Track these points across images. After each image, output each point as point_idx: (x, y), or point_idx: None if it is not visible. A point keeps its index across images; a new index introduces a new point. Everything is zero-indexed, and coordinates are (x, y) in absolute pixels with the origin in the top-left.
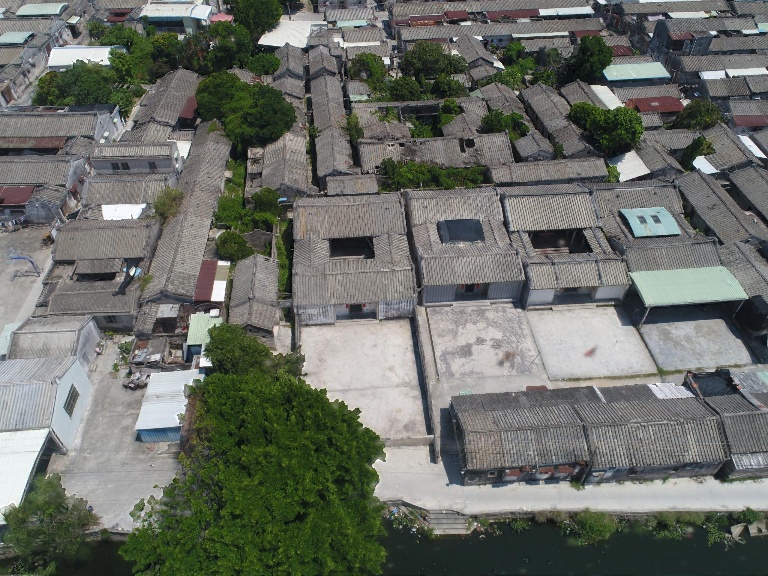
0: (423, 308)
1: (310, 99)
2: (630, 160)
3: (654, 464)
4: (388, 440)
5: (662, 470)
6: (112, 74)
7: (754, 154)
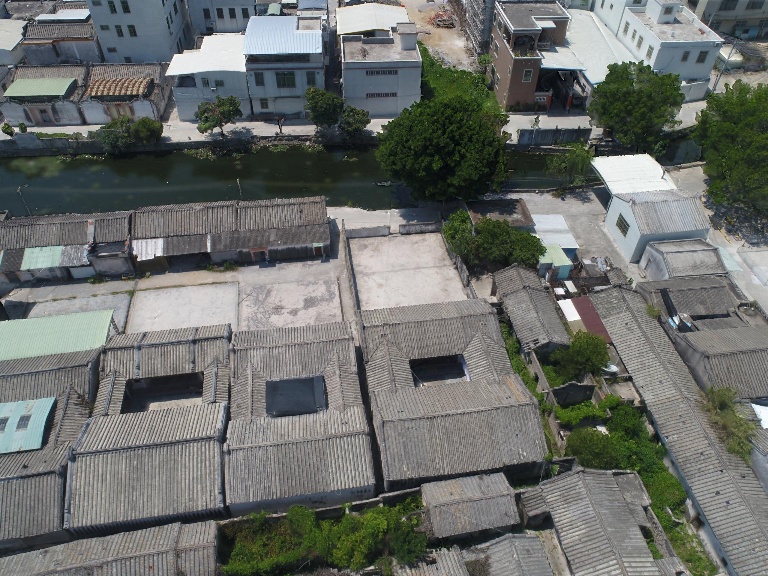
0: None
1: None
2: None
3: None
4: (379, 227)
5: None
6: None
7: None
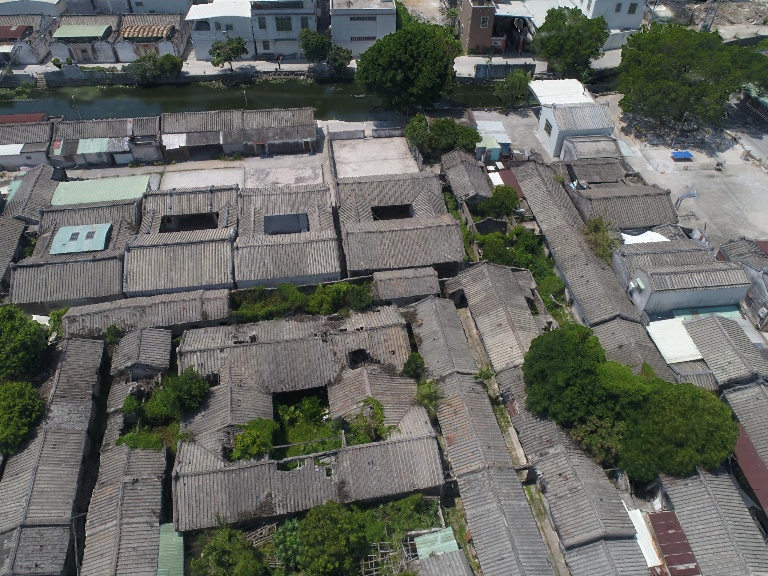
0: None
1: None
2: None
3: None
4: (356, 131)
5: None
6: None
7: None
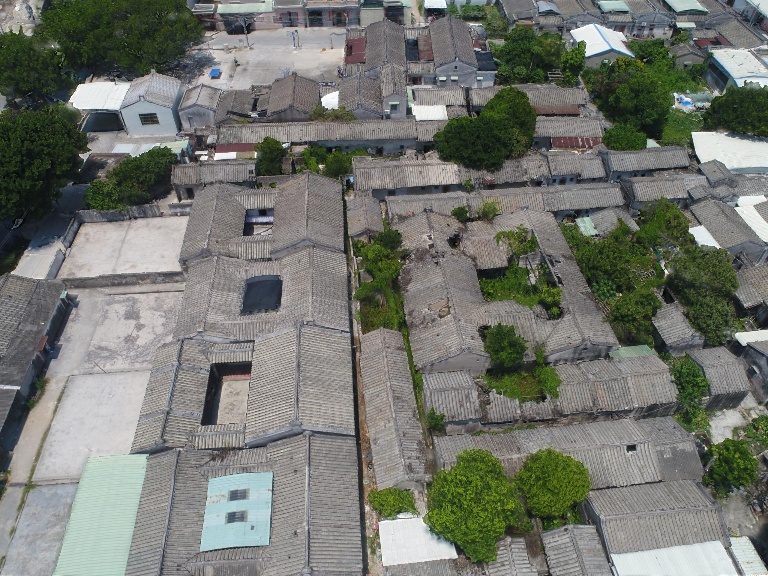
0: None
1: None
2: (431, 545)
3: None
4: None
5: None
6: (541, 54)
7: None
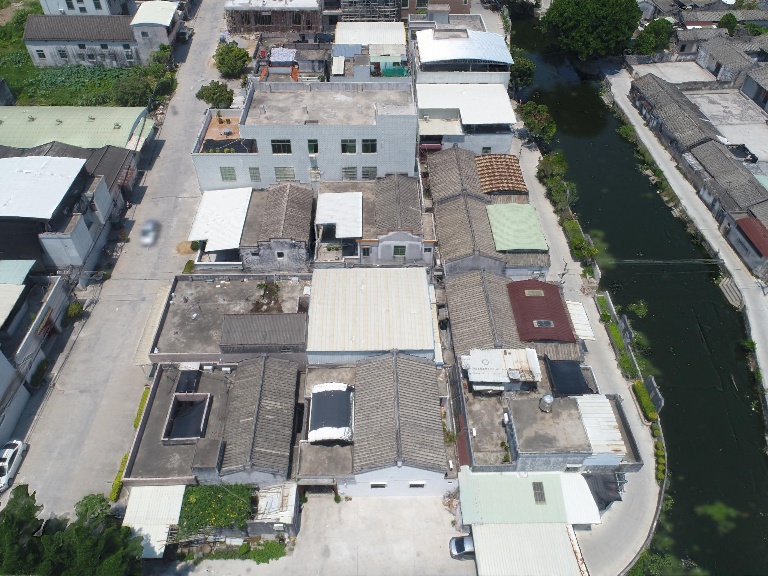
0: (738, 92)
1: None
2: None
3: (667, 125)
4: None
5: None
6: None
7: None
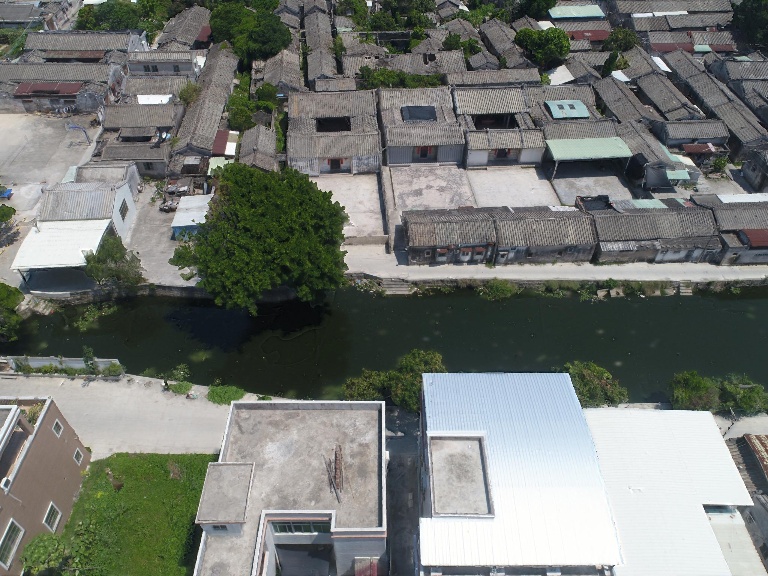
0: (387, 167)
1: (304, 32)
2: (560, 72)
3: (543, 245)
4: (355, 237)
5: (550, 253)
6: (139, 7)
7: (661, 68)
